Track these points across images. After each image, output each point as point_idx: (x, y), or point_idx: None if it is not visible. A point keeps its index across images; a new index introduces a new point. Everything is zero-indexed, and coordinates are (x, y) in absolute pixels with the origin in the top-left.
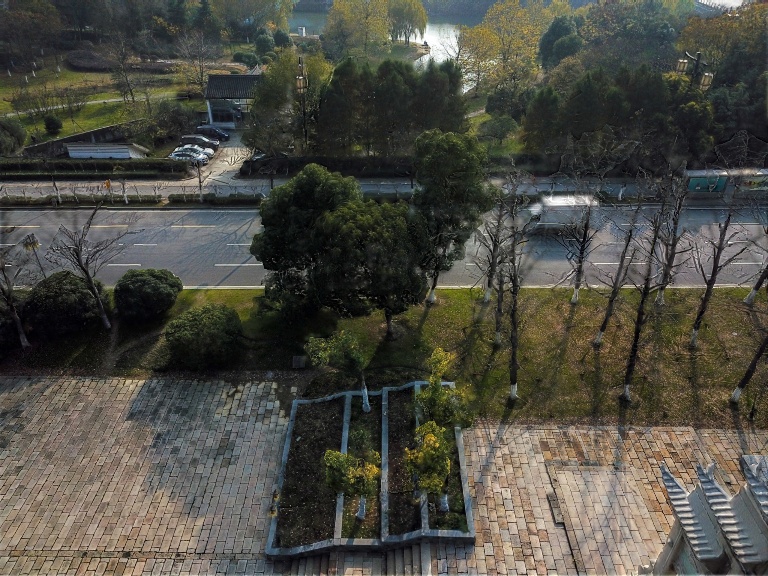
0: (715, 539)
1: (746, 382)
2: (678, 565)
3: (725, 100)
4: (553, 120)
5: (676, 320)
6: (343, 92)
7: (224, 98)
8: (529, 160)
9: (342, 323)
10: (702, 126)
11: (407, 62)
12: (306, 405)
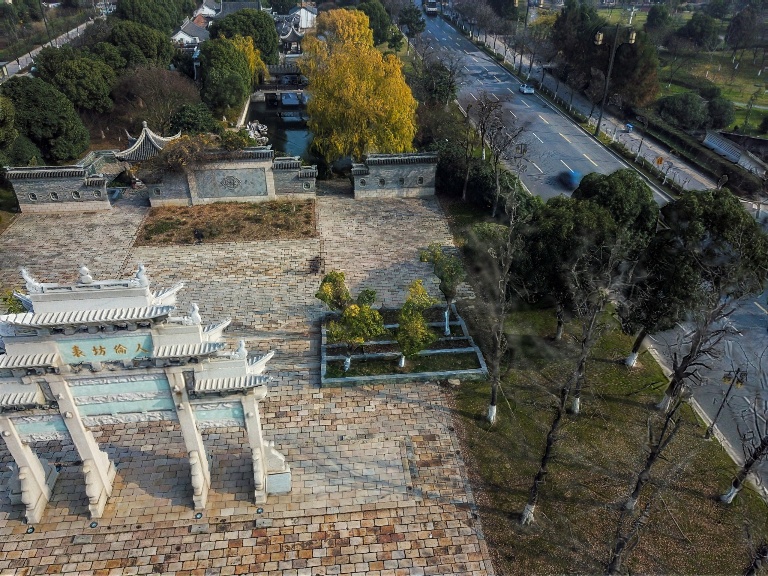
0: None
1: None
2: None
3: None
4: None
5: None
6: None
7: None
8: None
9: (554, 310)
10: None
11: None
12: None
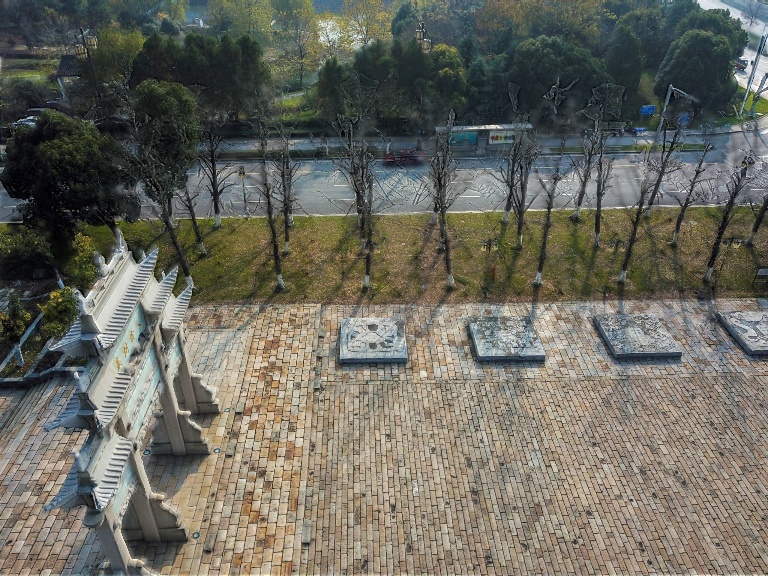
0: None
1: (369, 269)
2: None
3: (481, 67)
4: (337, 86)
5: None
6: (152, 63)
7: (74, 76)
8: (324, 123)
9: None
10: (457, 89)
11: (209, 37)
12: (26, 301)
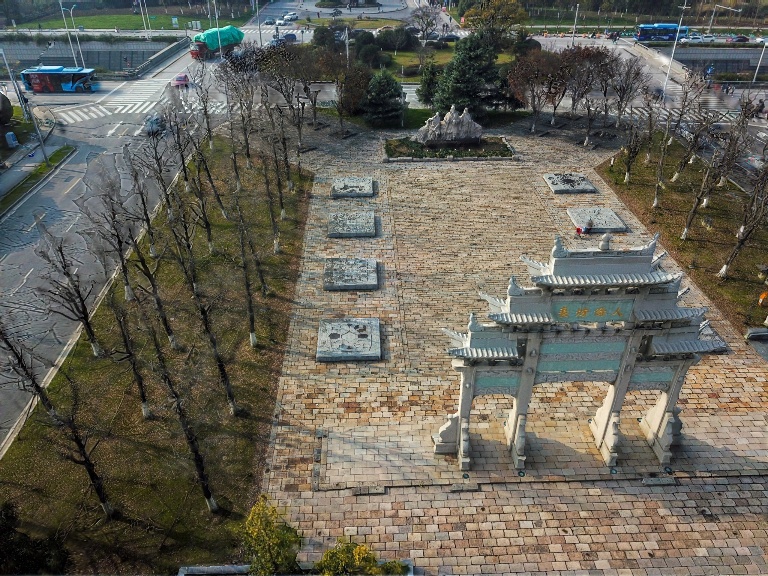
0: (508, 342)
1: None
2: (479, 390)
3: None
4: None
5: (136, 349)
6: None
7: None
8: None
9: None
10: None
11: None
12: None
